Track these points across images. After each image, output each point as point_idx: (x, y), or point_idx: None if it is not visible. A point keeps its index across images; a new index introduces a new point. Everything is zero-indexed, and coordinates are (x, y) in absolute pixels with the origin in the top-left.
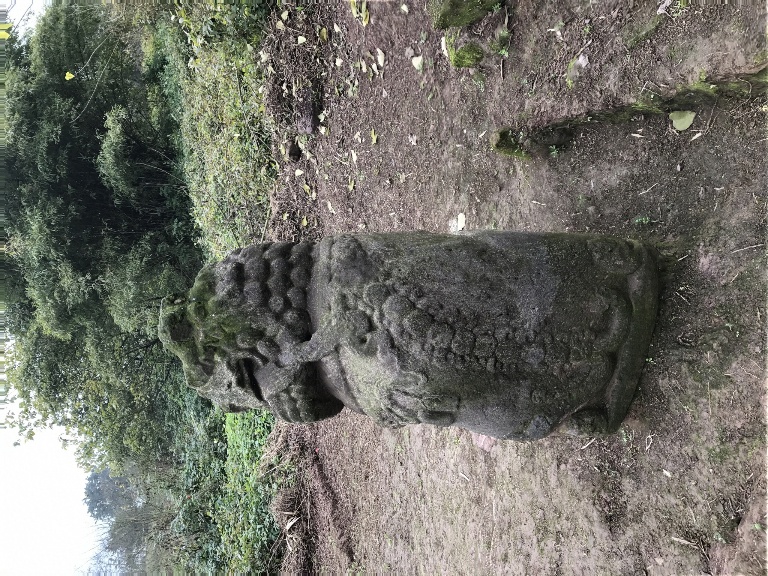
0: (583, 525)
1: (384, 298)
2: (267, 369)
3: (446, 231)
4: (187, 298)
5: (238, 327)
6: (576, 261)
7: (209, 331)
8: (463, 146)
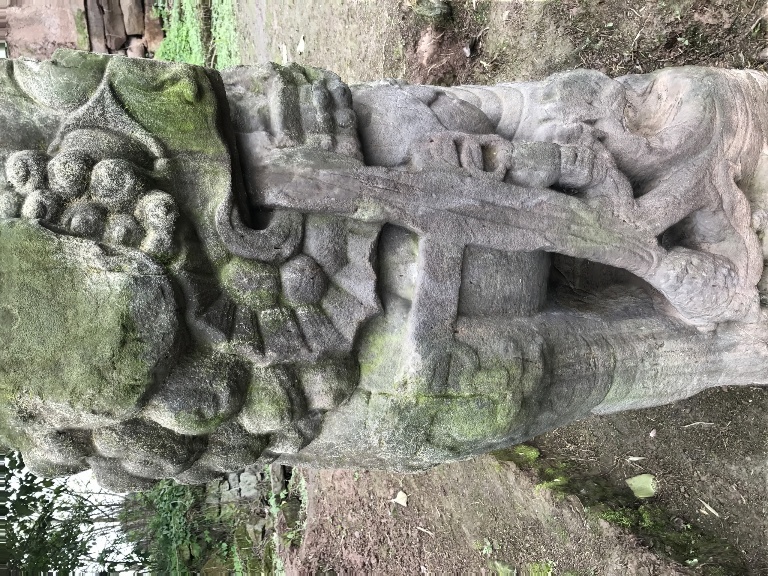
0: None
1: None
2: None
3: None
4: None
5: None
6: None
7: None
8: None
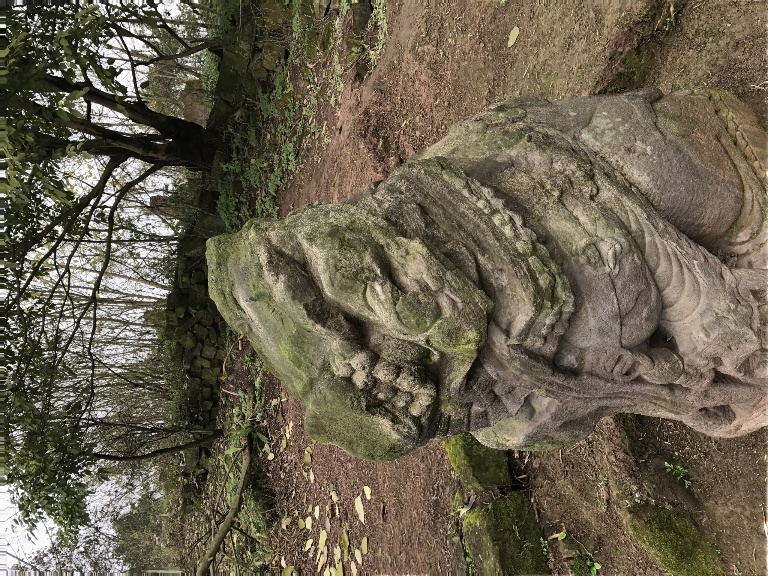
0: None
1: None
2: None
3: None
4: None
5: None
6: None
7: None
8: None
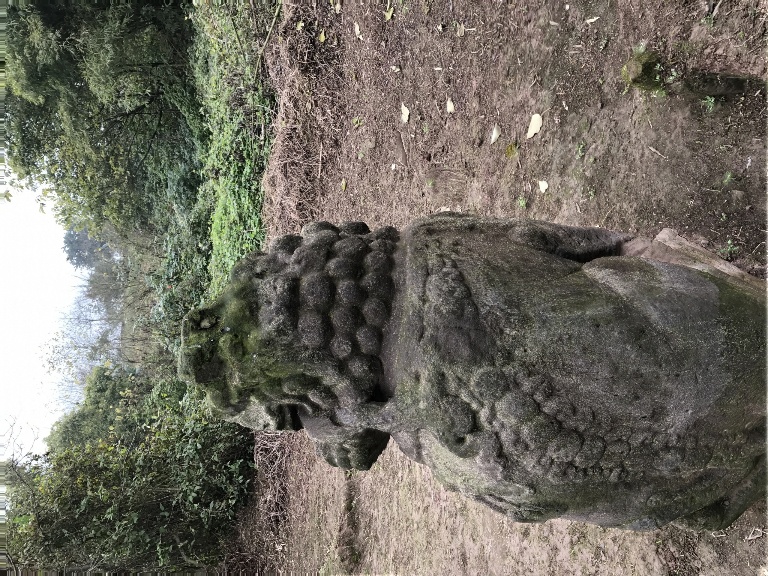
0: (637, 565)
1: (501, 394)
2: (318, 421)
3: (510, 125)
4: (218, 322)
5: (286, 372)
6: (759, 355)
7: (248, 378)
8: (560, 26)
